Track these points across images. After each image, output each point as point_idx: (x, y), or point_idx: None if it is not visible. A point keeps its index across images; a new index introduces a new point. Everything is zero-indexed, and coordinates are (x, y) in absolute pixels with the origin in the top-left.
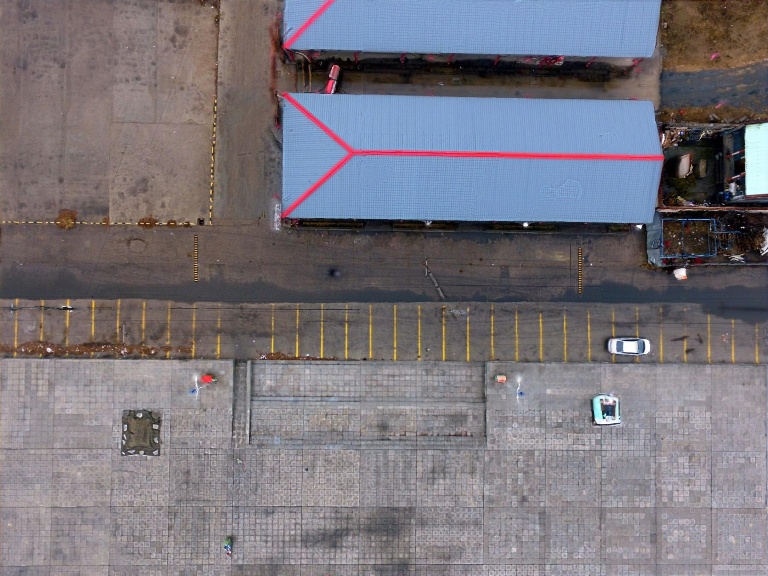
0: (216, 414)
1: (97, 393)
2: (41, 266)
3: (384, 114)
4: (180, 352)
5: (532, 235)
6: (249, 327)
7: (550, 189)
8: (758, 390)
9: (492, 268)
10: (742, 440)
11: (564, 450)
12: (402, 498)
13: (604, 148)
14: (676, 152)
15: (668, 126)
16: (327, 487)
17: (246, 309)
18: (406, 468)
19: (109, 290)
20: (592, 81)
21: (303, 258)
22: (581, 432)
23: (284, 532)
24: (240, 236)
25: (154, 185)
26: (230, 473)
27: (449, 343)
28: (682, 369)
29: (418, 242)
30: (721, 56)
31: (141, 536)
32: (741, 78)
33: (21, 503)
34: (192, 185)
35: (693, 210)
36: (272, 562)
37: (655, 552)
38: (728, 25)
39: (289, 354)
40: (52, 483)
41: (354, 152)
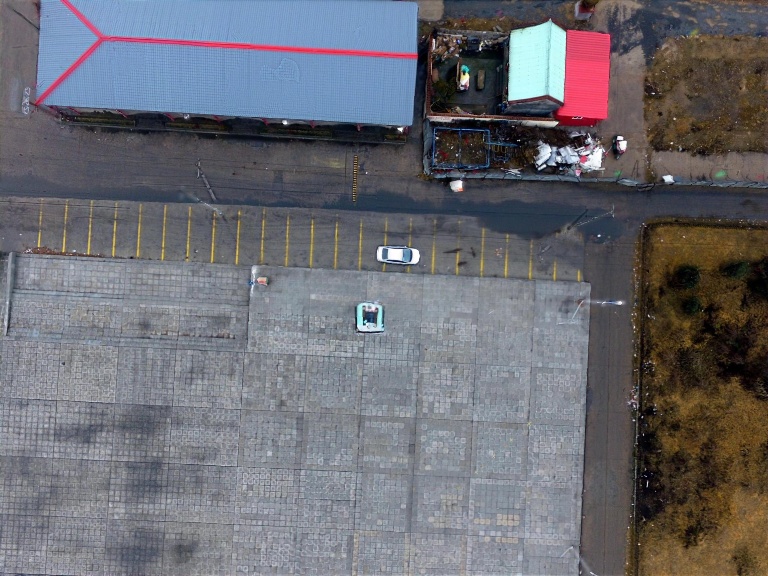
0: None
1: None
2: None
3: (141, 3)
4: None
5: (307, 141)
6: (16, 220)
7: (270, 70)
8: (526, 305)
9: (265, 172)
10: (507, 354)
11: (326, 356)
12: (159, 397)
13: (355, 43)
14: (456, 62)
15: (441, 32)
16: (83, 382)
17: (14, 202)
18: (164, 367)
19: None
20: None
21: (74, 154)
22: (344, 339)
23: (38, 425)
24: (12, 129)
25: None
26: None
27: (218, 245)
28: (450, 280)
29: (192, 143)
30: None
31: None
32: None
33: None
34: None
35: (464, 119)
36: (24, 454)
37: (413, 462)
38: None
39: (55, 249)
40: None
41: (102, 37)
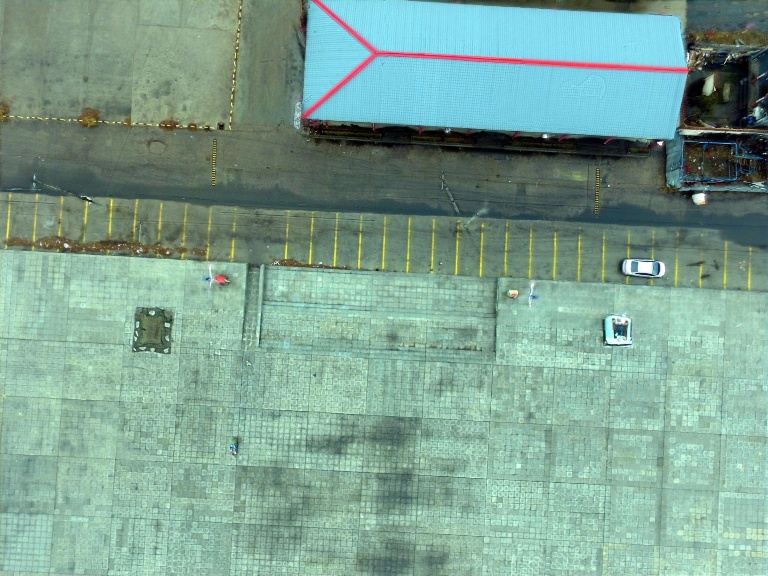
0: (227, 315)
1: (111, 289)
2: (62, 163)
3: (408, 18)
4: (194, 254)
5: (550, 154)
6: (264, 233)
7: (572, 86)
8: None
9: (508, 185)
10: (755, 368)
11: (573, 369)
12: (408, 408)
13: (628, 58)
14: (700, 76)
15: (693, 46)
16: (334, 393)
17: (261, 215)
18: (414, 379)
19: (127, 190)
20: (617, 2)
21: (320, 167)
22: (591, 352)
23: (290, 436)
24: (259, 142)
25: (176, 88)
26: (239, 375)
27: (462, 258)
28: (697, 293)
29: (435, 156)
30: None
31: (148, 432)
32: None
33: (32, 393)
34: (213, 90)
35: (715, 132)
36: (276, 465)
37: (661, 476)
38: None
39: (302, 261)
40: (63, 375)
41: (376, 53)
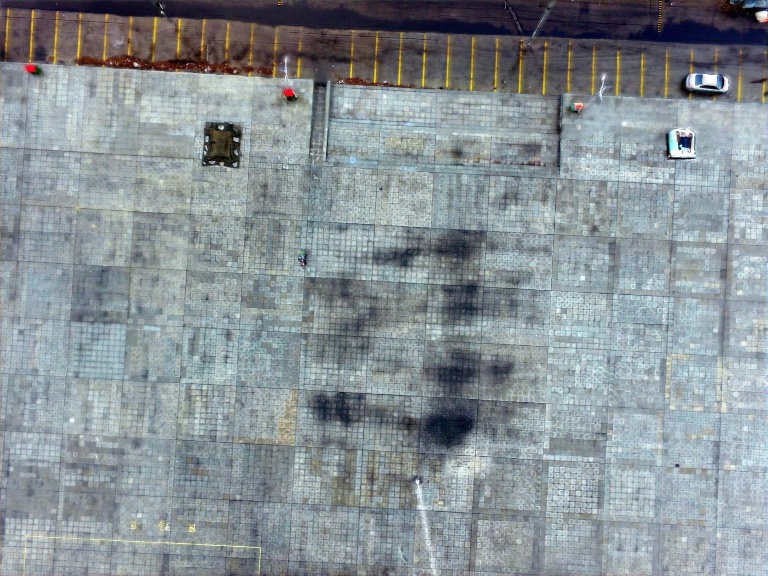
0: (295, 130)
1: (181, 104)
2: None
3: None
4: (261, 73)
5: None
6: (329, 52)
7: None
8: None
9: (571, 4)
10: None
11: (637, 182)
12: (473, 222)
13: None
14: None
15: None
16: (400, 207)
17: (327, 35)
18: (479, 192)
19: (195, 10)
20: None
21: None
22: (655, 166)
23: (356, 248)
24: None
25: None
26: (306, 188)
27: (525, 76)
28: (760, 108)
29: None
30: None
31: (218, 244)
32: None
33: (105, 206)
34: None
35: None
36: (344, 277)
37: (724, 288)
38: None
39: (367, 80)
40: (135, 188)
41: None
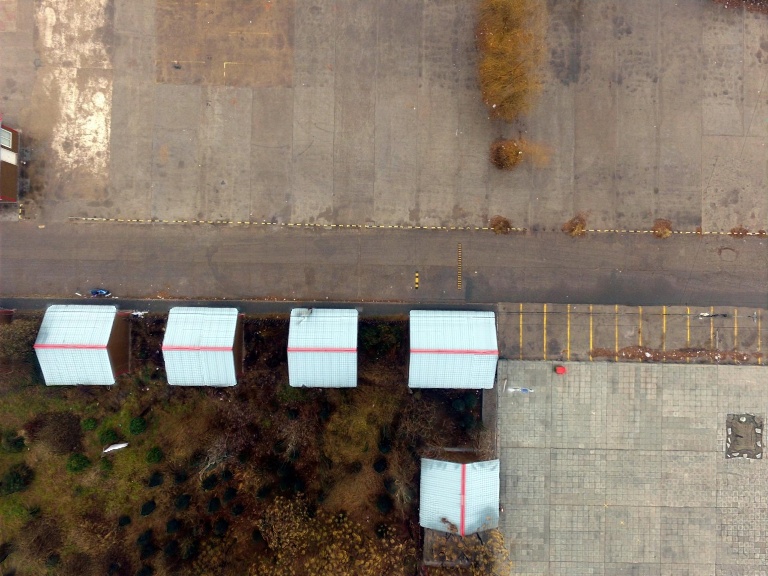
0: None
1: (702, 397)
2: (639, 273)
3: None
4: None
5: None
6: None
7: None
8: None
9: None
10: None
11: None
12: None
13: None
14: None
15: None
16: None
17: None
18: None
19: (702, 297)
20: None
21: None
22: None
23: None
24: None
25: (744, 196)
26: None
27: None
28: None
29: None
30: None
31: (745, 536)
32: None
33: (632, 502)
34: None
35: None
36: None
37: None
38: None
39: None
40: (661, 483)
41: None
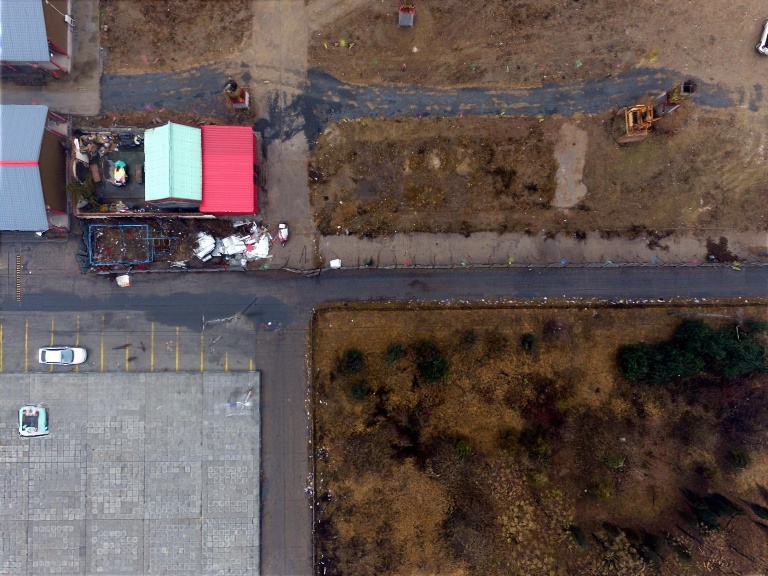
0: None
1: None
2: None
3: None
4: None
5: None
6: None
7: None
8: (194, 398)
9: None
10: (177, 449)
11: None
12: None
13: None
14: (115, 157)
15: (86, 131)
16: None
17: None
18: None
19: None
20: (29, 85)
21: None
22: (8, 444)
23: None
24: None
25: None
26: None
27: None
28: (115, 378)
29: None
30: (166, 59)
31: None
32: (185, 81)
33: None
34: None
35: (117, 216)
36: None
37: (84, 565)
38: (172, 28)
39: None
40: None
41: None
